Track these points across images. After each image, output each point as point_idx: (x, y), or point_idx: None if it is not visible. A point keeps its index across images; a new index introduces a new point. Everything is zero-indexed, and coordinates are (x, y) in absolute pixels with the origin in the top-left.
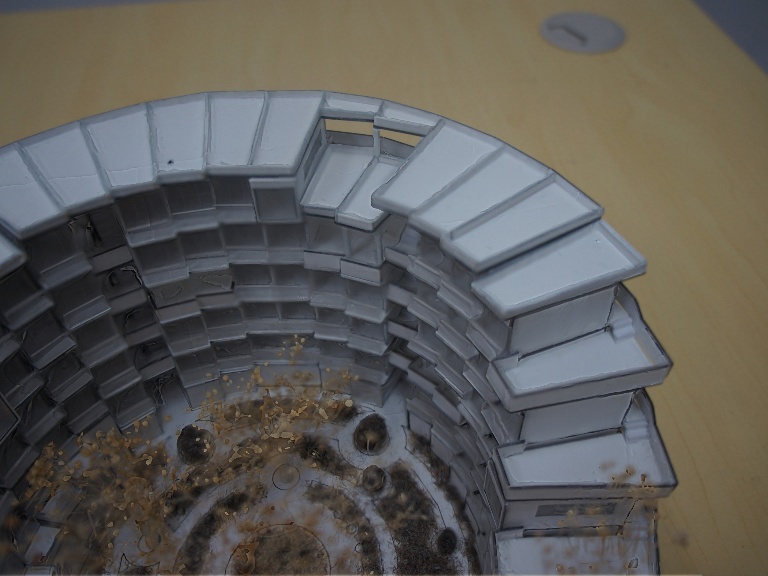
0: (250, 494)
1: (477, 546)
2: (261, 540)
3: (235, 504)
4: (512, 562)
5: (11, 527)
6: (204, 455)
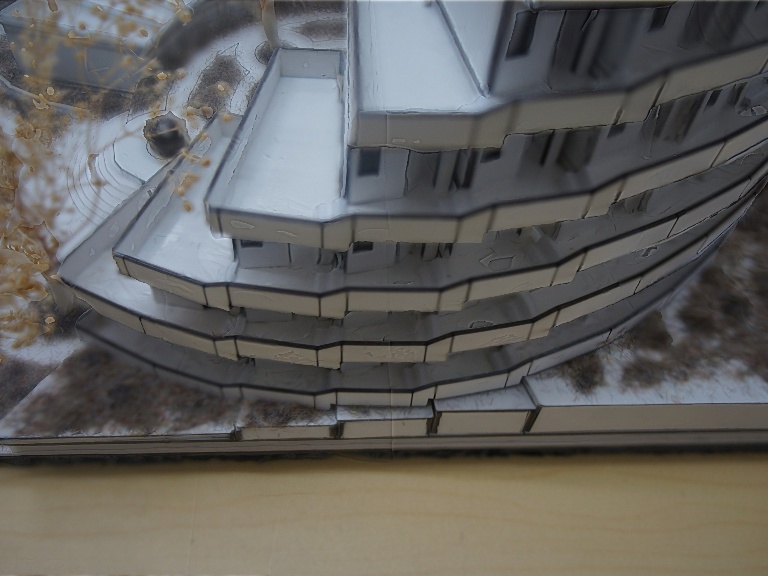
0: None
1: None
2: None
3: None
4: (240, 152)
5: None
6: None
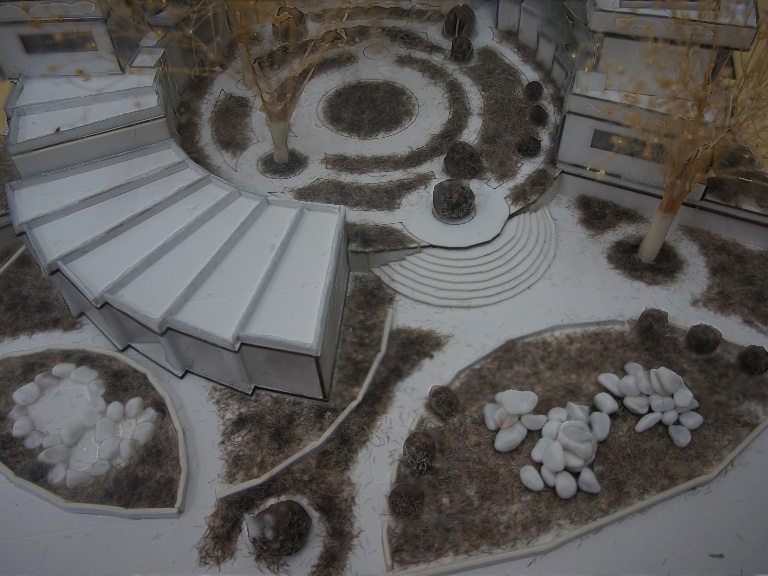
0: (342, 59)
1: (564, 88)
2: (352, 86)
3: (328, 64)
4: None
5: (128, 4)
6: (298, 32)
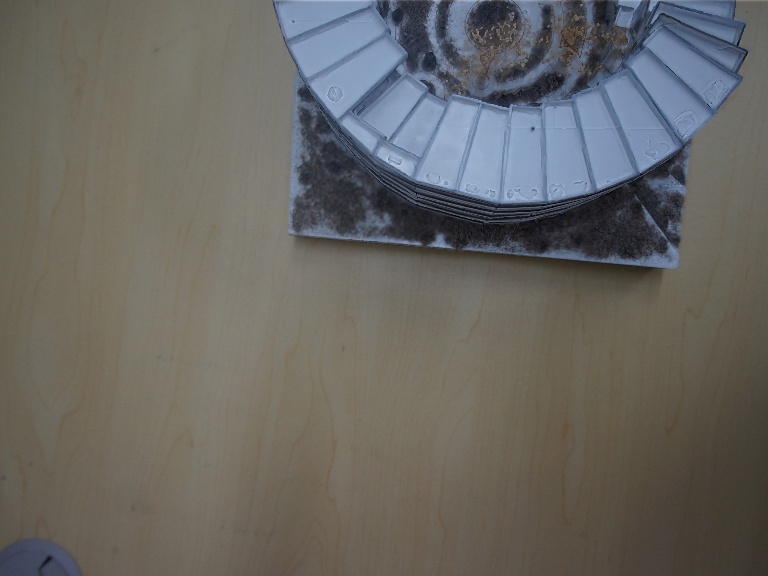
0: (504, 75)
1: None
2: None
3: (514, 71)
4: None
5: None
6: None
